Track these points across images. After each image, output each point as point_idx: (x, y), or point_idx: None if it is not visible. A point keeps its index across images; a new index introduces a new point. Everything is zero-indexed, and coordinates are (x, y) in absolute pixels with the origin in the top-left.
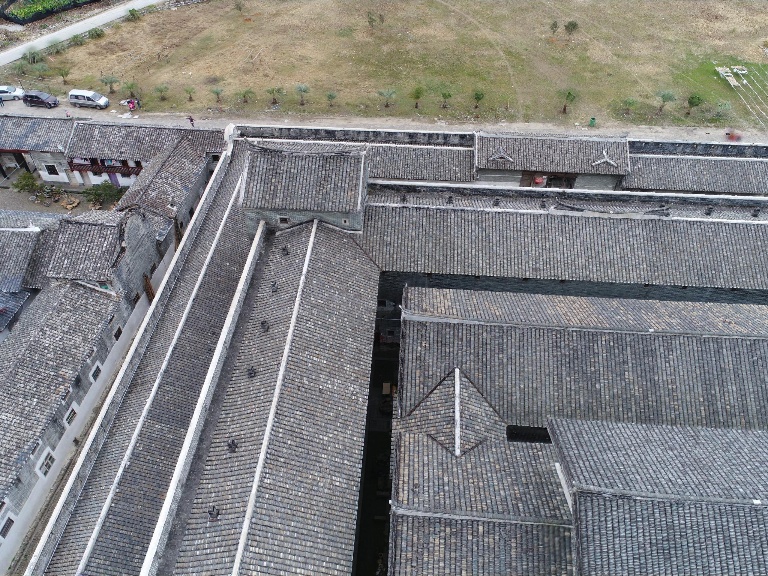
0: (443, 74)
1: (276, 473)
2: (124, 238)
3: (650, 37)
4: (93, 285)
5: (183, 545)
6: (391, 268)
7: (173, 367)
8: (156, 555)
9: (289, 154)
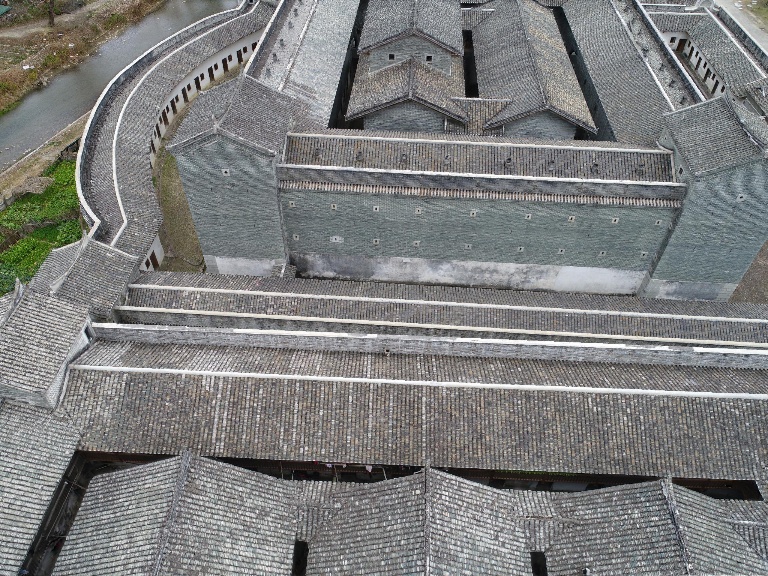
0: None
1: None
2: None
3: None
4: None
5: None
6: (564, 7)
7: None
8: None
9: None
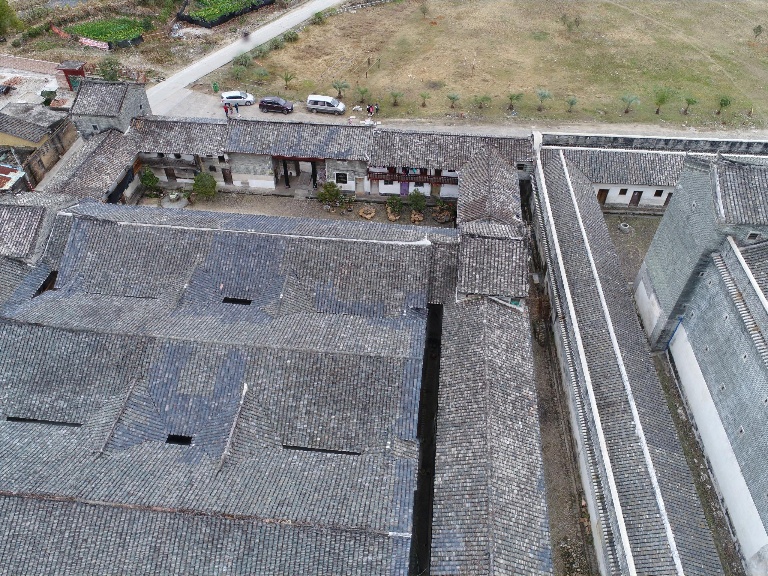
0: (663, 79)
1: None
2: None
3: None
4: (504, 301)
5: None
6: None
7: (633, 387)
8: None
9: (757, 168)
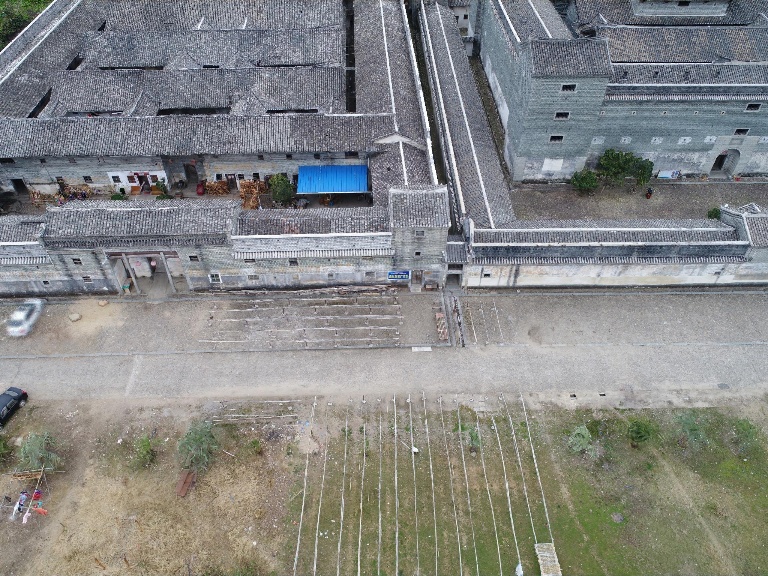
0: None
1: None
2: None
3: None
4: None
5: None
6: None
7: None
8: None
9: None
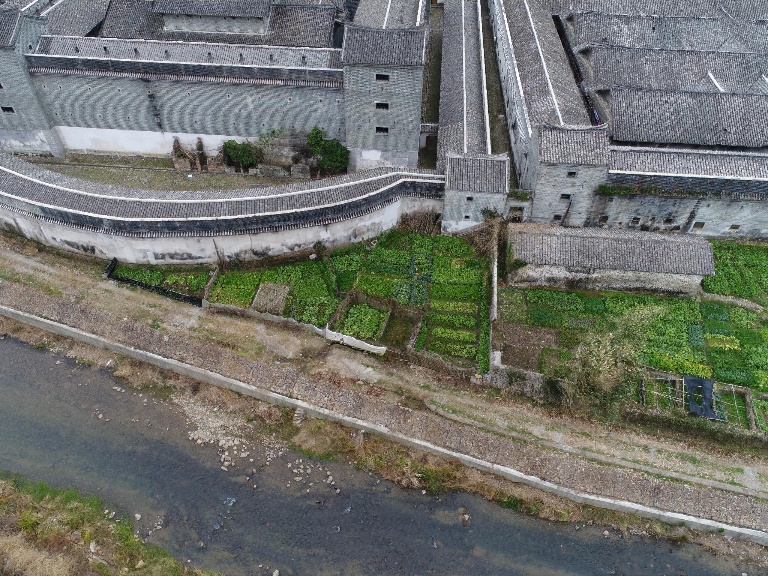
0: None
1: None
2: None
3: None
4: None
5: None
6: None
7: None
8: (30, 11)
9: None
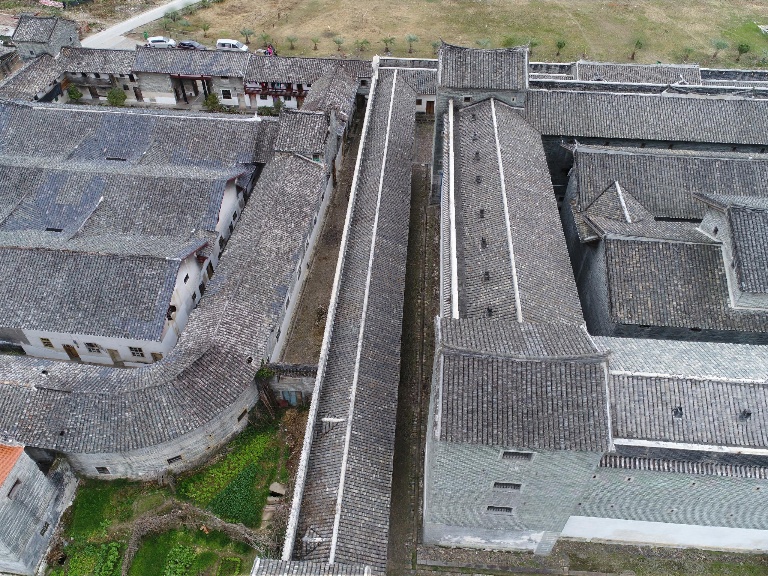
0: (524, 30)
1: (517, 225)
2: (329, 124)
3: (697, 3)
4: (308, 158)
5: (466, 262)
6: (548, 132)
7: (384, 208)
8: None
9: (471, 51)
